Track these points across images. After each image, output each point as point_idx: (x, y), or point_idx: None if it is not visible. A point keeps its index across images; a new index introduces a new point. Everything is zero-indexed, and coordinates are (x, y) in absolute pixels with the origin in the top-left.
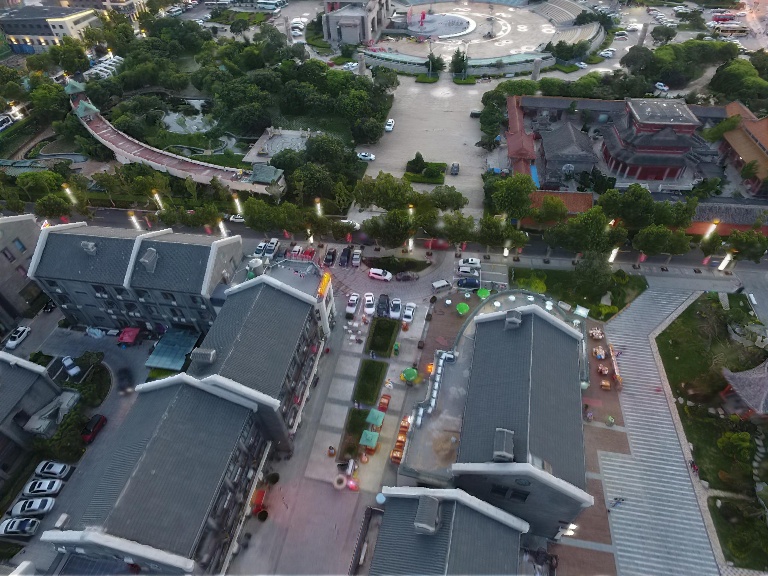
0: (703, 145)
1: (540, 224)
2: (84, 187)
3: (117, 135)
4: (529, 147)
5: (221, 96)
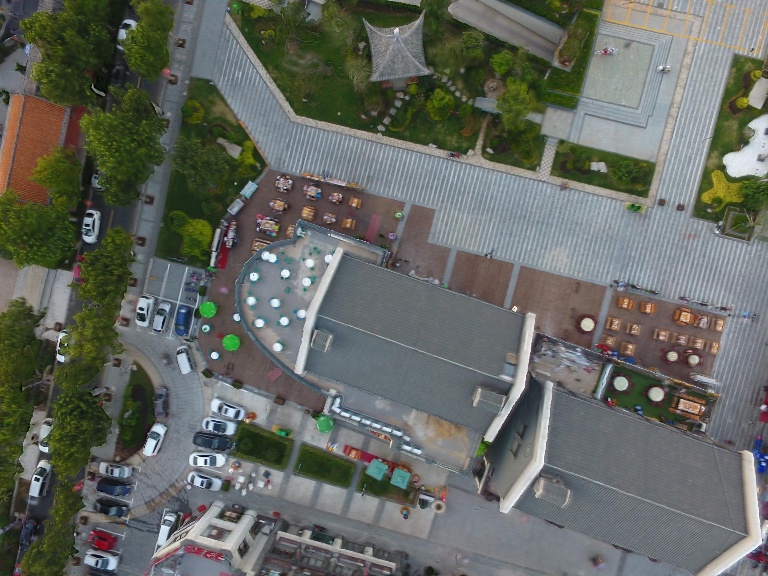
0: None
1: None
2: None
3: None
4: None
5: None
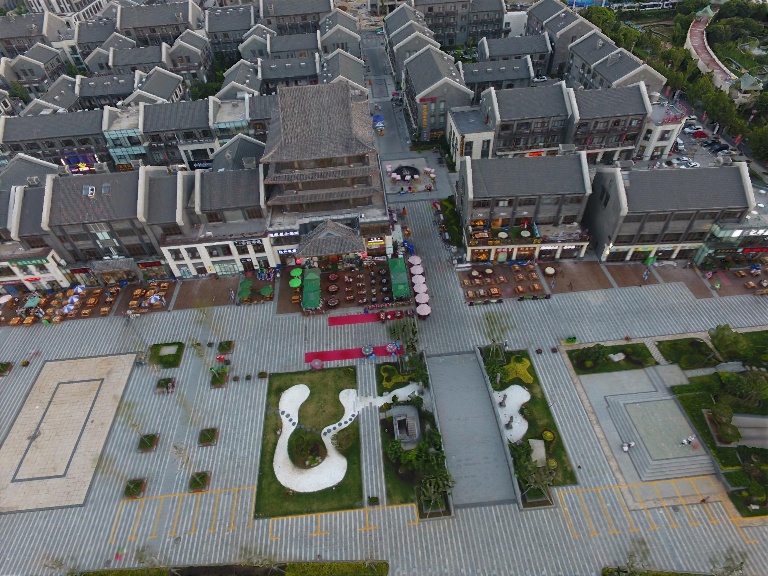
0: None
1: None
2: (643, 44)
3: (701, 33)
4: None
5: None
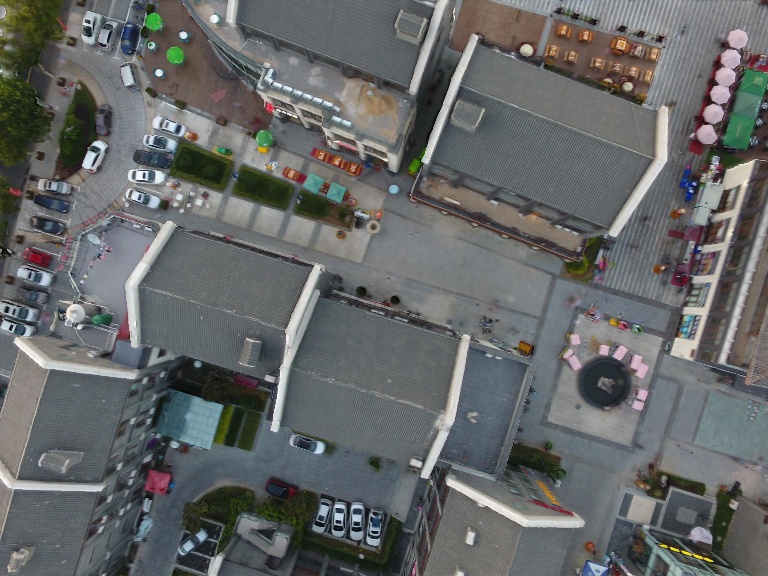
0: None
1: None
2: None
3: None
4: None
5: None
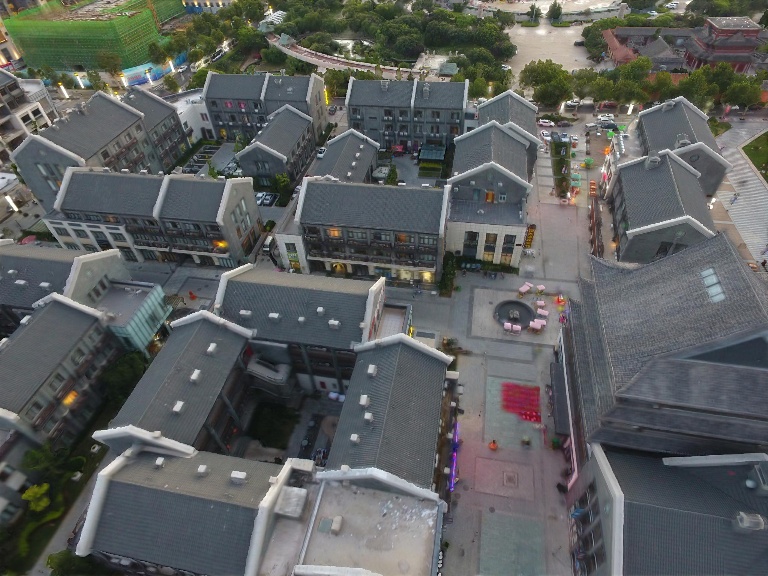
0: (761, 53)
1: (650, 96)
2: None
3: (316, 56)
4: (632, 55)
5: (382, 32)
